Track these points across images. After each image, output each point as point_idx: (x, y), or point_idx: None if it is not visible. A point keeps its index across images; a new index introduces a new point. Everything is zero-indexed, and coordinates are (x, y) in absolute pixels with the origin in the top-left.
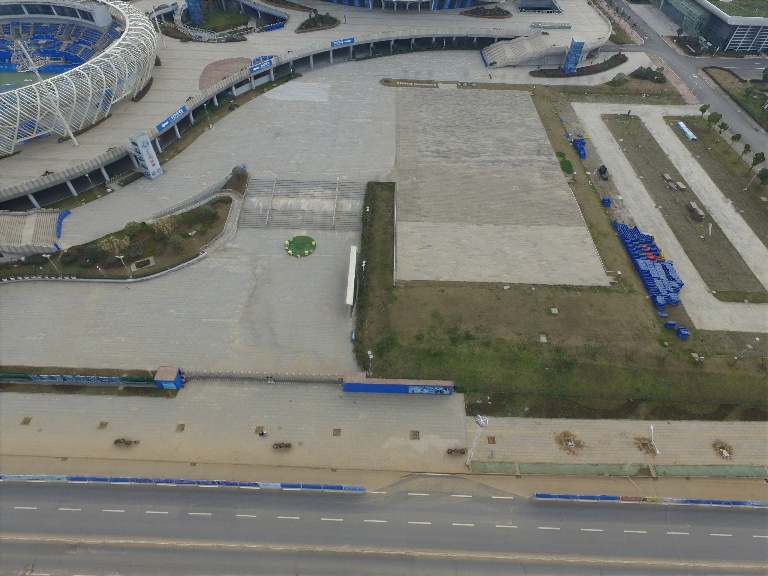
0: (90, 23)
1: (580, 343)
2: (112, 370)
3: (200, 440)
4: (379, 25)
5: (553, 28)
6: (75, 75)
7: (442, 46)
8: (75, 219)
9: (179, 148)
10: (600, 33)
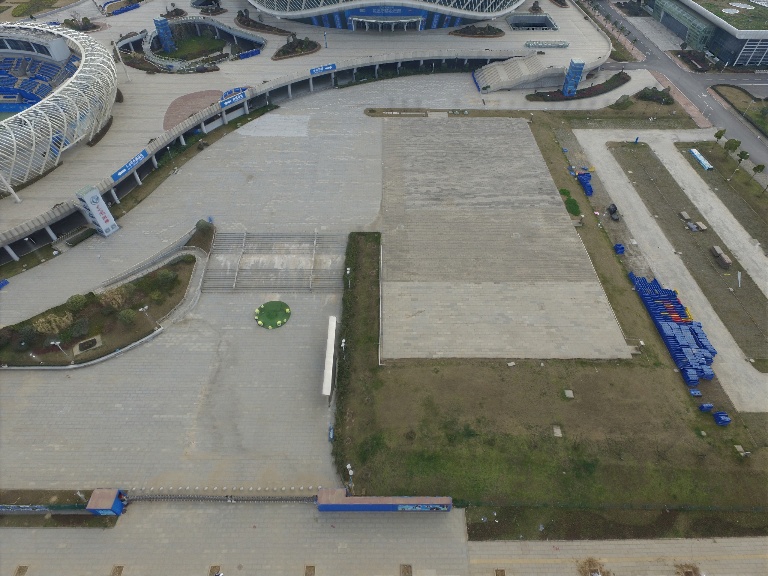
0: (46, 57)
1: (602, 437)
2: (40, 491)
3: None
4: (362, 49)
5: (549, 47)
6: (15, 123)
7: (431, 69)
8: (13, 290)
9: (139, 197)
10: (600, 51)
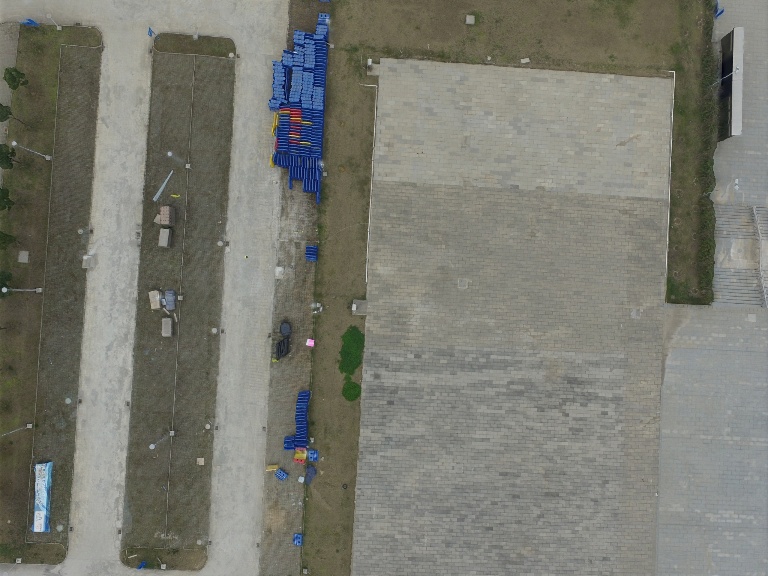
0: None
1: None
2: None
3: None
4: None
5: None
6: None
7: None
8: None
9: None
10: None
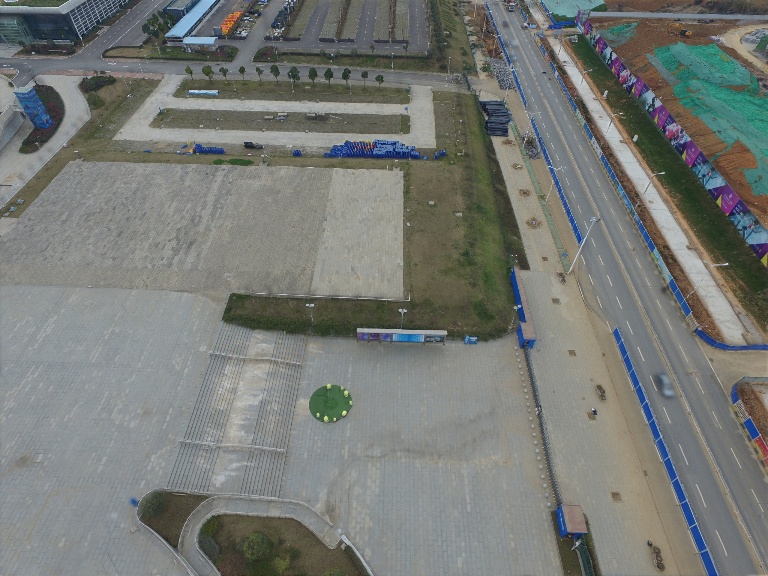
0: None
1: (460, 197)
2: None
3: (621, 472)
4: None
5: None
6: None
7: None
8: None
9: None
10: None
